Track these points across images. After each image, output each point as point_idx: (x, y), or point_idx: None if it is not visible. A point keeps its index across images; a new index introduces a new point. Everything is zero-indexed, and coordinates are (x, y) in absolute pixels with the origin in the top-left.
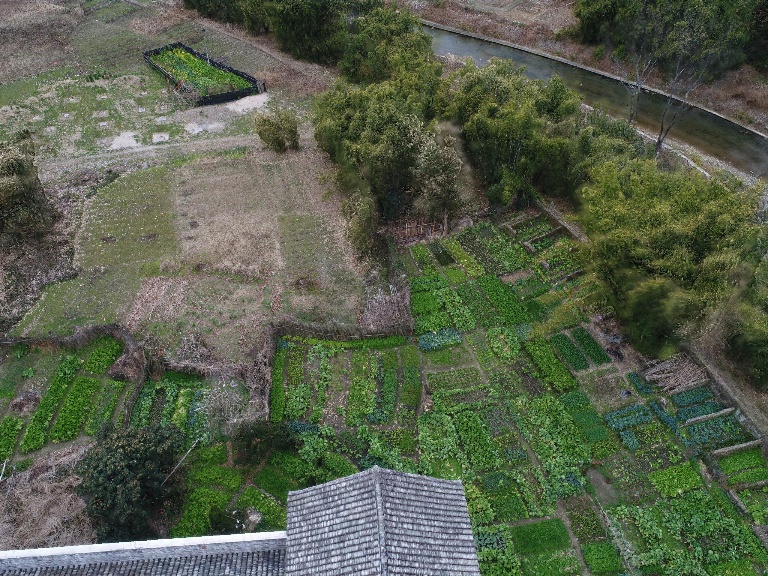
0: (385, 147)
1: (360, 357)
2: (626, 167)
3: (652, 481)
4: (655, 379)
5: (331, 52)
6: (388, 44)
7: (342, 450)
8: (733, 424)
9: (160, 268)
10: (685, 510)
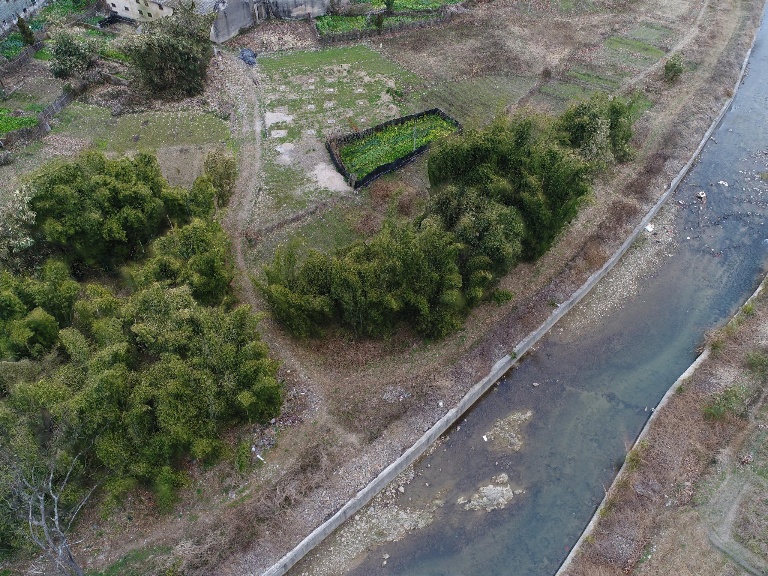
0: None
1: None
2: None
3: None
4: None
5: None
6: None
7: None
8: None
9: None
10: None
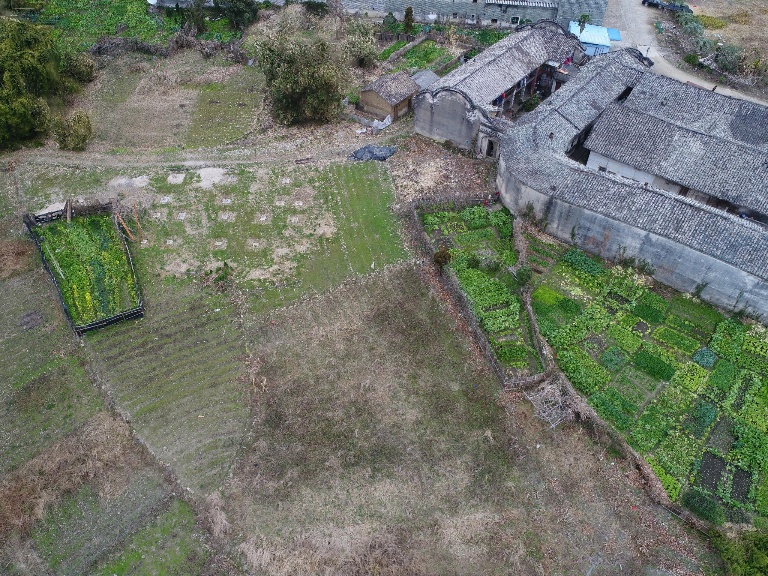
0: None
1: None
2: None
3: None
4: None
5: None
6: None
7: None
8: None
9: (212, 79)
10: (64, 5)
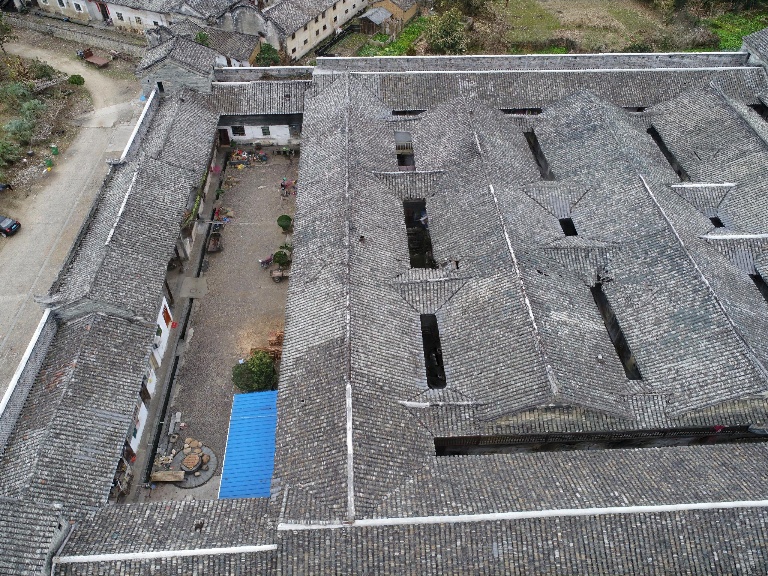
0: None
1: None
2: None
3: None
4: None
5: None
6: None
7: None
8: None
9: (562, 24)
10: None
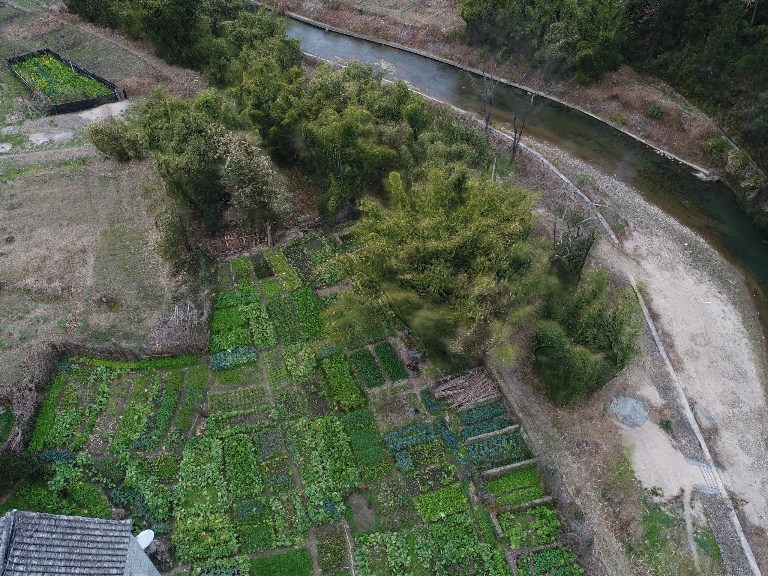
0: (190, 158)
1: (144, 378)
2: (453, 174)
3: (416, 505)
4: (445, 396)
5: (202, 57)
6: (250, 49)
7: (96, 479)
8: (516, 442)
9: None
10: (441, 535)
